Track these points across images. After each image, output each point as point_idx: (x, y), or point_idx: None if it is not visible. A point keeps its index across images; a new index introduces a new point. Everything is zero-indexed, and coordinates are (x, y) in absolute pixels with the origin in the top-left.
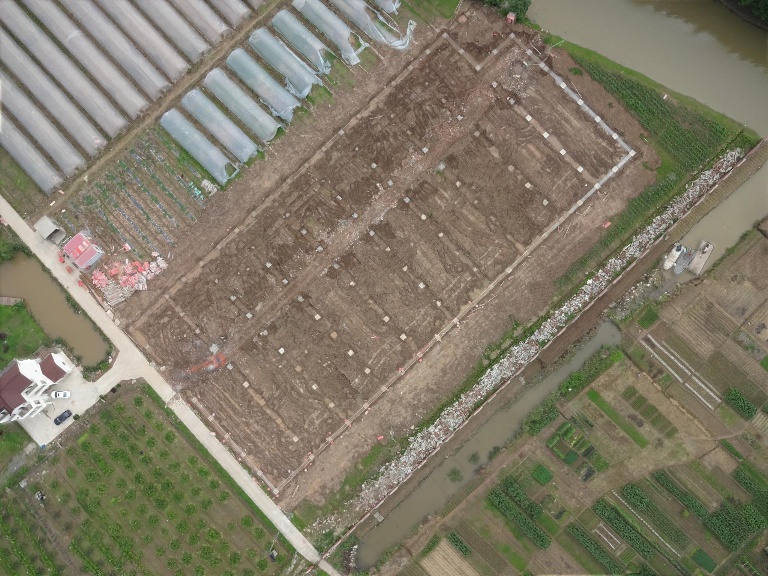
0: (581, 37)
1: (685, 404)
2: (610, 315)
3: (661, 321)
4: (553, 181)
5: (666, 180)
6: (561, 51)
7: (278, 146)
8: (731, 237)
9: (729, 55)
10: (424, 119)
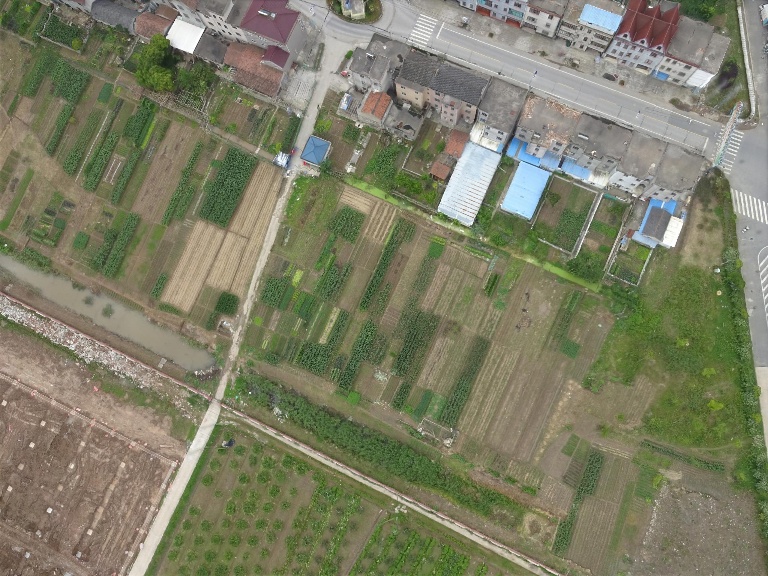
0: None
1: None
2: None
3: None
4: None
5: None
6: None
7: None
8: None
9: None
10: None
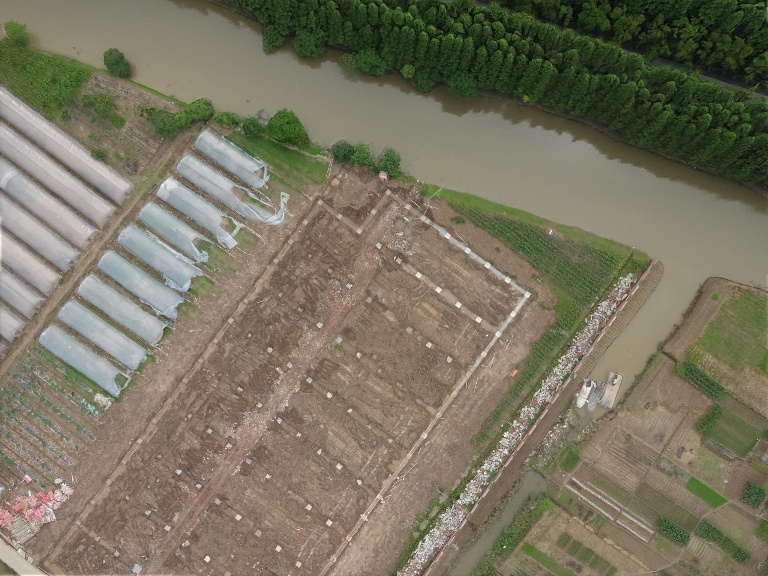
0: (458, 182)
1: (619, 542)
2: (532, 464)
3: (583, 462)
4: (453, 337)
5: (565, 318)
6: (440, 201)
7: (167, 346)
8: (638, 363)
9: (612, 159)
10: (313, 294)
